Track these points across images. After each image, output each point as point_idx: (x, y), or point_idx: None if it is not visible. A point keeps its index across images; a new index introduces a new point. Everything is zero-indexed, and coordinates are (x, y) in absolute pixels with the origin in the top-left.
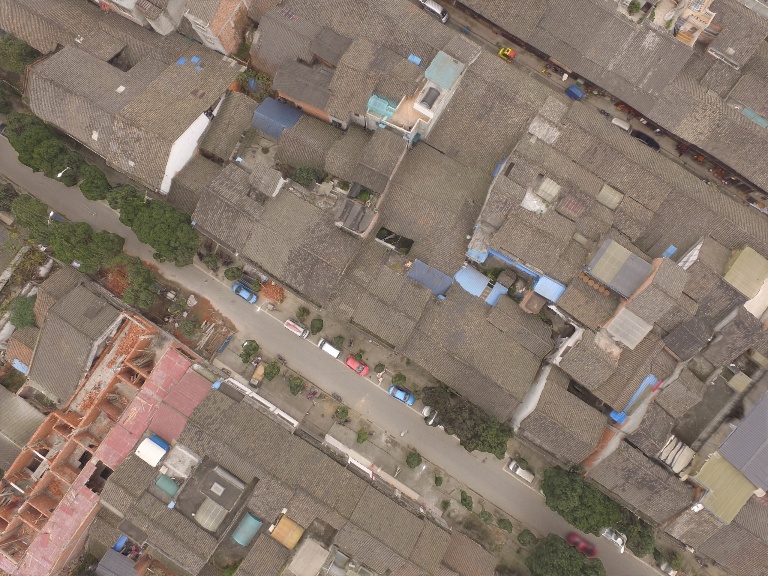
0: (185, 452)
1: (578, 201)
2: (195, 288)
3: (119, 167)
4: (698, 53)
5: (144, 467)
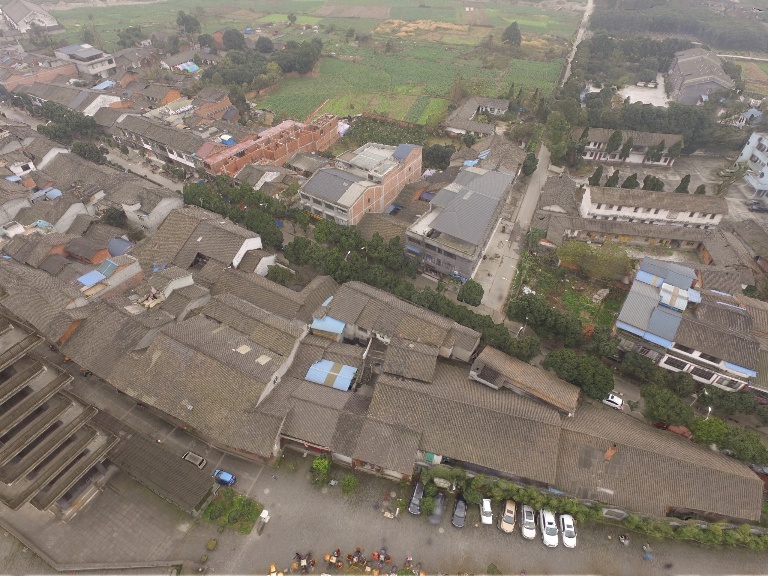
0: None
1: None
2: None
3: None
4: None
5: None
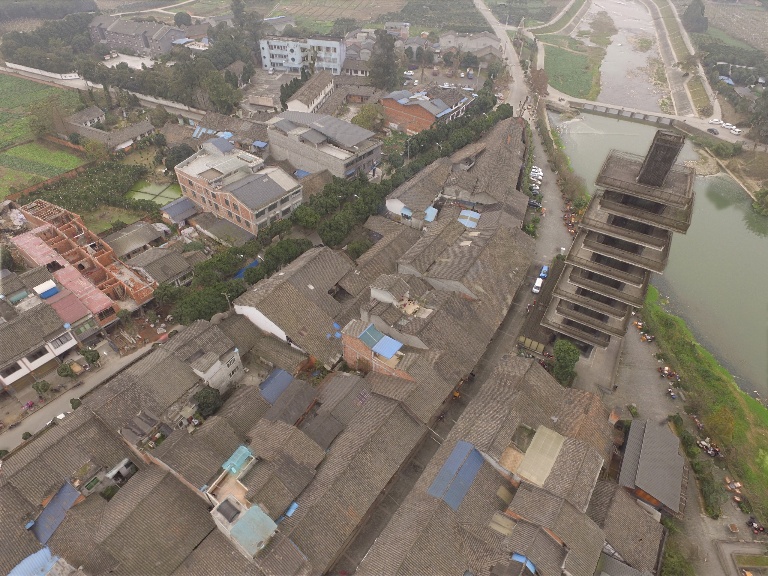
0: None
1: None
2: None
3: None
4: None
5: None
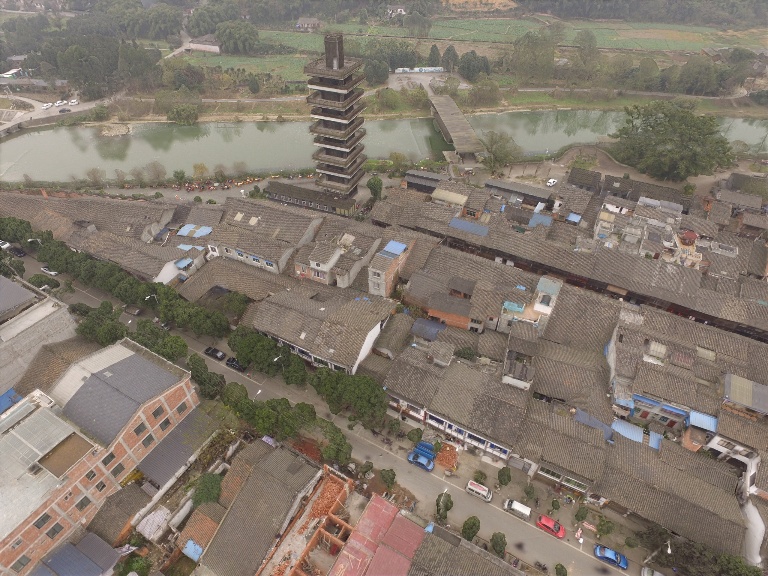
0: None
1: (685, 354)
2: None
3: (320, 355)
4: (704, 276)
5: None
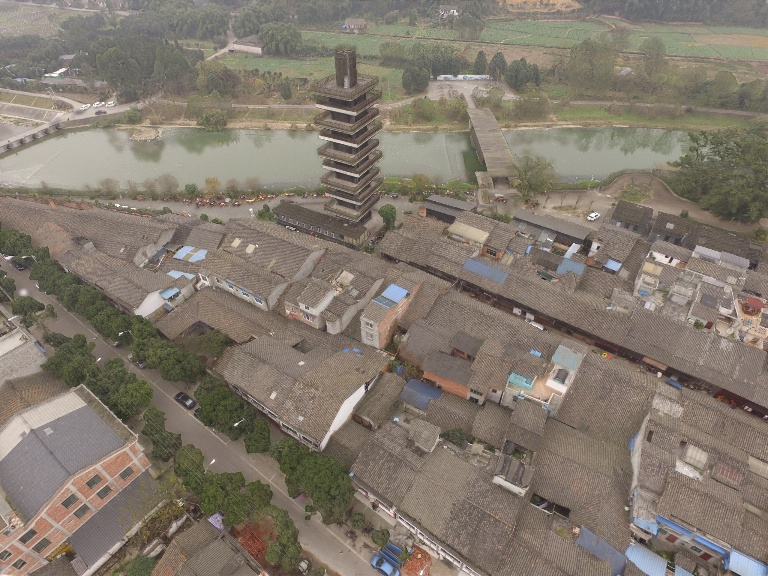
0: None
1: (732, 468)
2: (328, 560)
3: (288, 422)
4: None
5: None
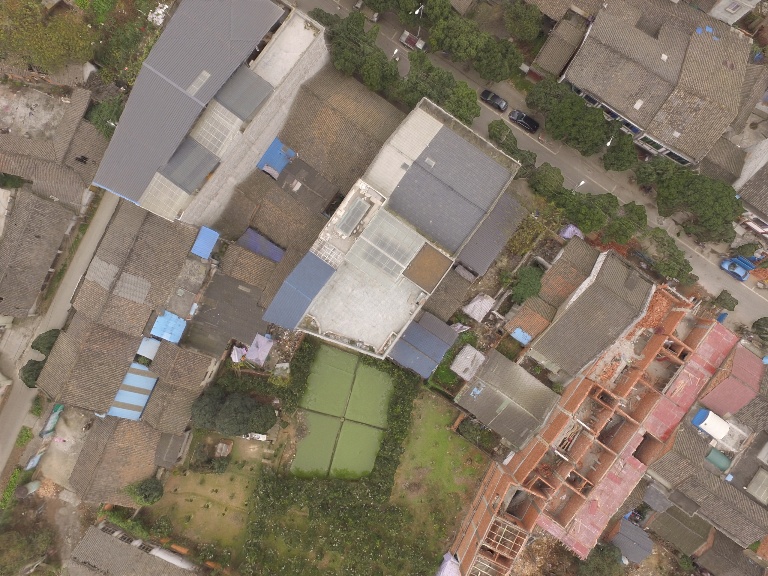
0: (734, 426)
1: None
2: None
3: (658, 138)
4: None
5: (695, 439)
